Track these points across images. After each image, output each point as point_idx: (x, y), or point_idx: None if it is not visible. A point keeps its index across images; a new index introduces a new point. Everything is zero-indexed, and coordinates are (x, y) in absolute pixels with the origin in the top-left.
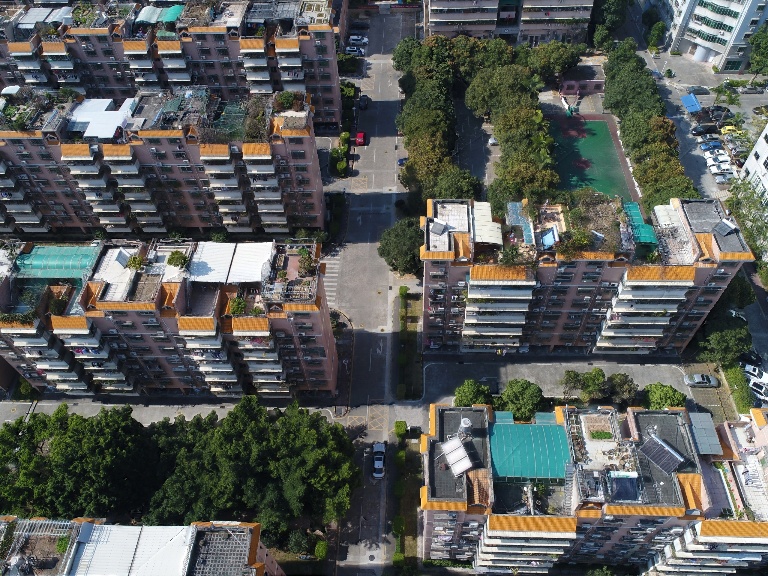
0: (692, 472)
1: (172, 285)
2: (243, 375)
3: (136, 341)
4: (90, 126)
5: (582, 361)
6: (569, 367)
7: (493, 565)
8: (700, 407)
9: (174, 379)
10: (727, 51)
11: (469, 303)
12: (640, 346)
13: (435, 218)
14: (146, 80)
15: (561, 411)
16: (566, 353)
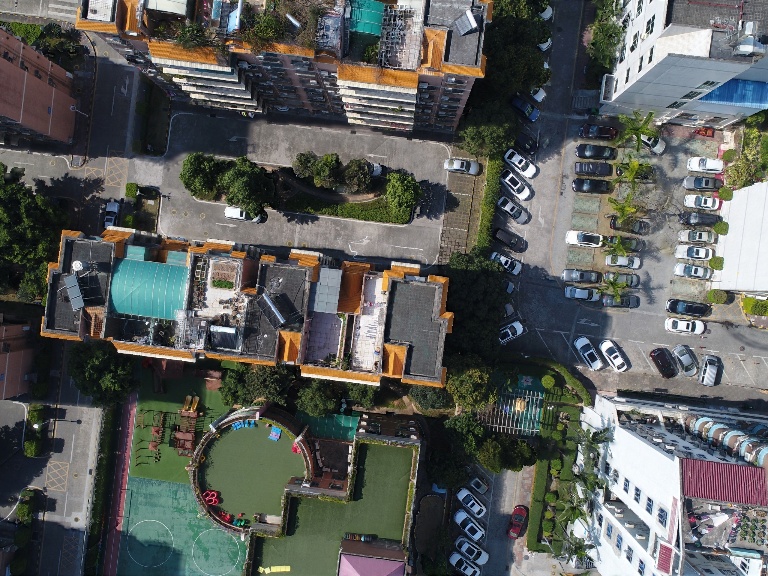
0: (298, 328)
1: None
2: None
3: None
4: None
5: (345, 128)
6: (329, 134)
7: None
8: (450, 195)
9: None
10: None
11: None
12: None
13: None
14: None
15: None
16: (330, 116)
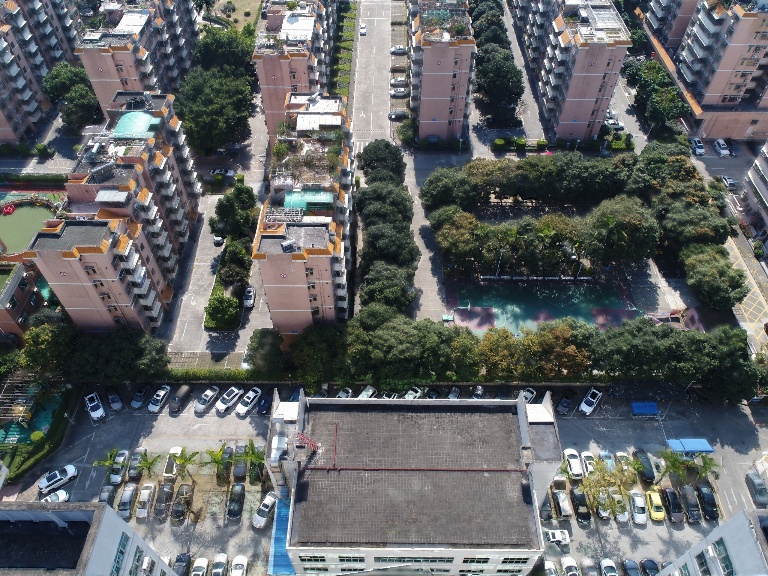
0: None
1: None
2: None
3: None
4: None
5: None
6: None
7: None
8: (226, 355)
9: None
10: None
11: None
12: None
13: None
14: (533, 7)
15: None
16: None
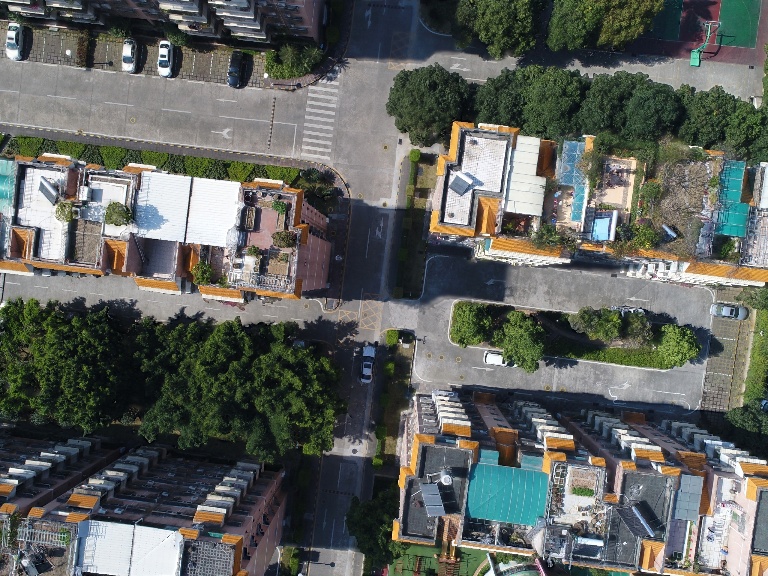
0: (658, 536)
1: (118, 243)
2: None
3: None
4: None
5: (606, 271)
6: (589, 277)
7: None
8: (714, 340)
9: None
10: None
11: None
12: None
13: (458, 172)
14: None
15: (549, 462)
16: None
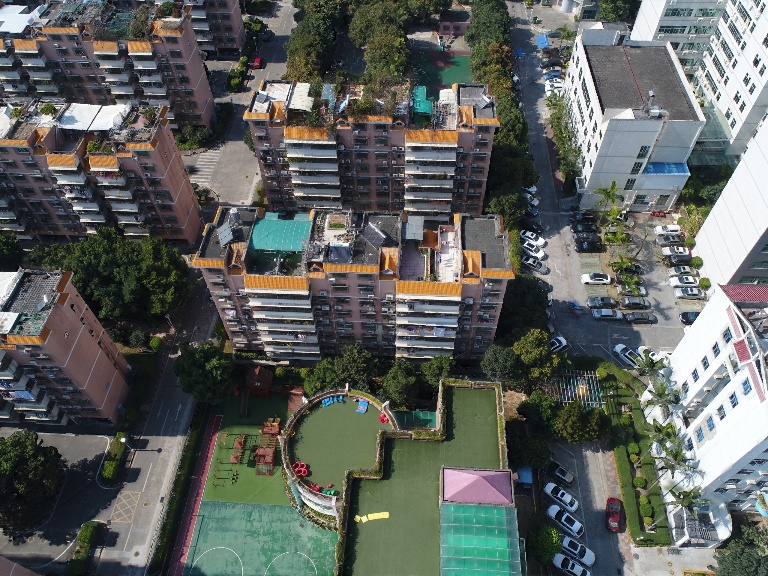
0: None
1: (44, 130)
2: (113, 221)
3: (20, 181)
4: (4, 24)
5: None
6: None
7: (273, 341)
8: None
9: (59, 225)
10: (582, 1)
11: (290, 163)
12: (438, 211)
13: (260, 90)
14: None
15: (312, 211)
16: None
